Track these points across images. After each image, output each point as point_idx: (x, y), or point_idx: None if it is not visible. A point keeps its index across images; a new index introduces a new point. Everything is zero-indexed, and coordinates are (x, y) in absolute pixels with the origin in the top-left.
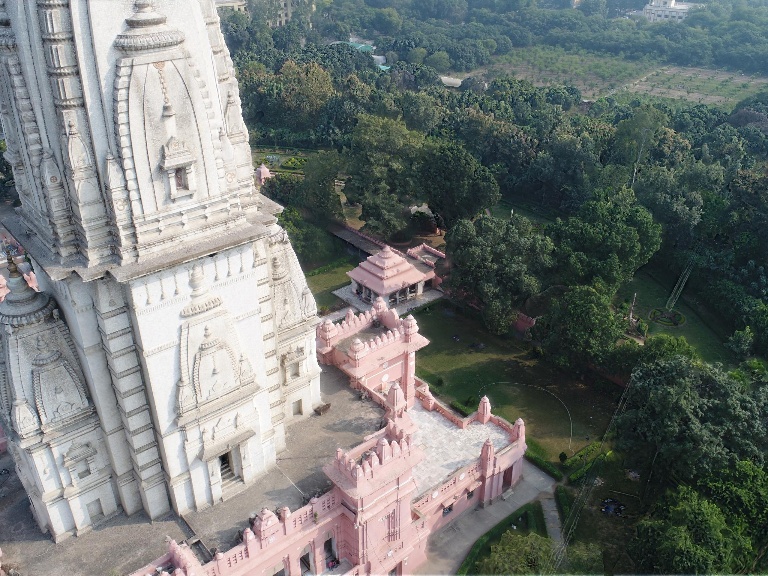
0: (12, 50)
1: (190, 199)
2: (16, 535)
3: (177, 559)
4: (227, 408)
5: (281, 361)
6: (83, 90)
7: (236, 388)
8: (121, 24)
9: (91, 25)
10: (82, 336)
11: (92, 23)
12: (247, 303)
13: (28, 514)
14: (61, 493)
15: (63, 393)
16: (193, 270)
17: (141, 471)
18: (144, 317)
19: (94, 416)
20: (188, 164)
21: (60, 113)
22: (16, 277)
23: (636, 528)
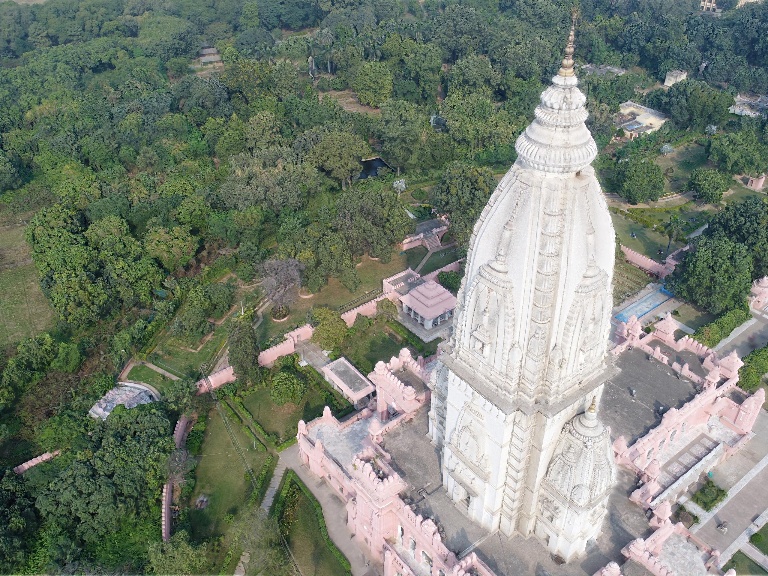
0: None
1: None
2: None
3: None
4: None
5: None
6: None
7: None
8: (488, 260)
9: None
10: None
11: None
12: None
13: None
14: None
15: None
16: None
17: None
18: None
19: None
20: None
21: None
22: None
23: None
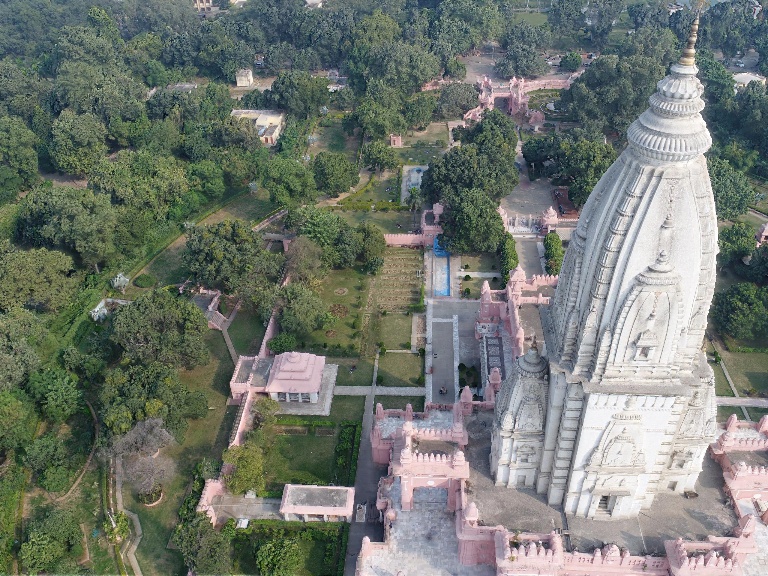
0: (581, 254)
1: (646, 361)
2: (478, 467)
3: (552, 543)
4: (619, 473)
5: (673, 454)
6: (608, 293)
7: (629, 466)
8: (645, 268)
9: (627, 266)
10: (554, 399)
11: (628, 265)
12: (658, 424)
13: (487, 458)
14: (509, 463)
15: (532, 418)
16: (631, 397)
17: (554, 478)
18: (591, 410)
19: (542, 436)
20: (652, 346)
21: (591, 298)
22: (534, 351)
23: None
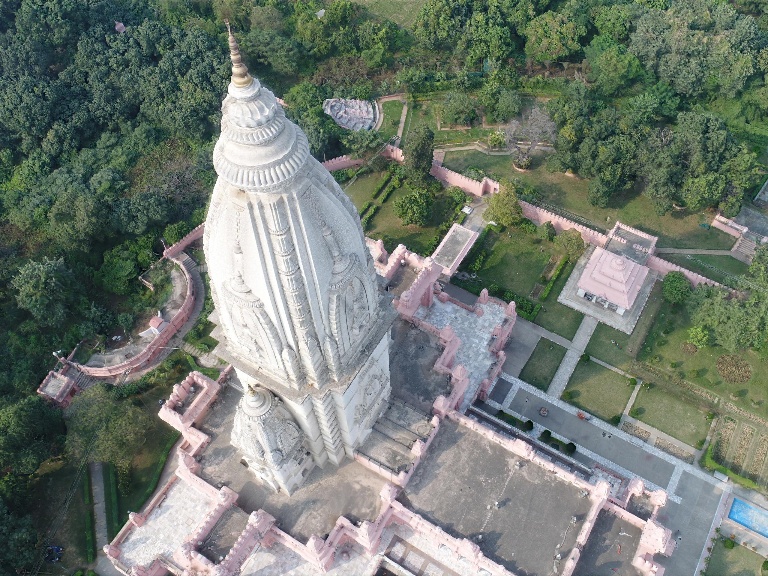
0: None
1: None
2: None
3: None
4: None
5: None
6: None
7: None
8: None
9: None
10: None
11: None
12: None
13: None
14: None
15: None
16: None
17: None
18: None
19: None
20: None
21: None
22: None
23: (42, 539)
